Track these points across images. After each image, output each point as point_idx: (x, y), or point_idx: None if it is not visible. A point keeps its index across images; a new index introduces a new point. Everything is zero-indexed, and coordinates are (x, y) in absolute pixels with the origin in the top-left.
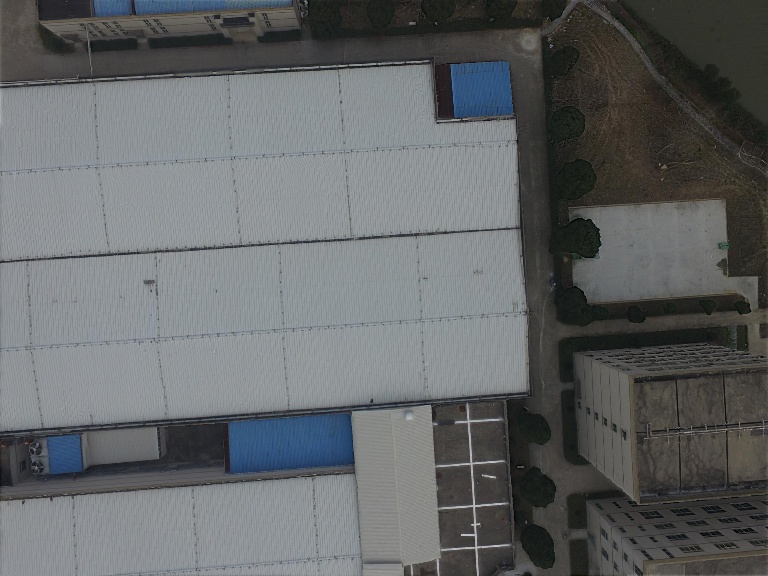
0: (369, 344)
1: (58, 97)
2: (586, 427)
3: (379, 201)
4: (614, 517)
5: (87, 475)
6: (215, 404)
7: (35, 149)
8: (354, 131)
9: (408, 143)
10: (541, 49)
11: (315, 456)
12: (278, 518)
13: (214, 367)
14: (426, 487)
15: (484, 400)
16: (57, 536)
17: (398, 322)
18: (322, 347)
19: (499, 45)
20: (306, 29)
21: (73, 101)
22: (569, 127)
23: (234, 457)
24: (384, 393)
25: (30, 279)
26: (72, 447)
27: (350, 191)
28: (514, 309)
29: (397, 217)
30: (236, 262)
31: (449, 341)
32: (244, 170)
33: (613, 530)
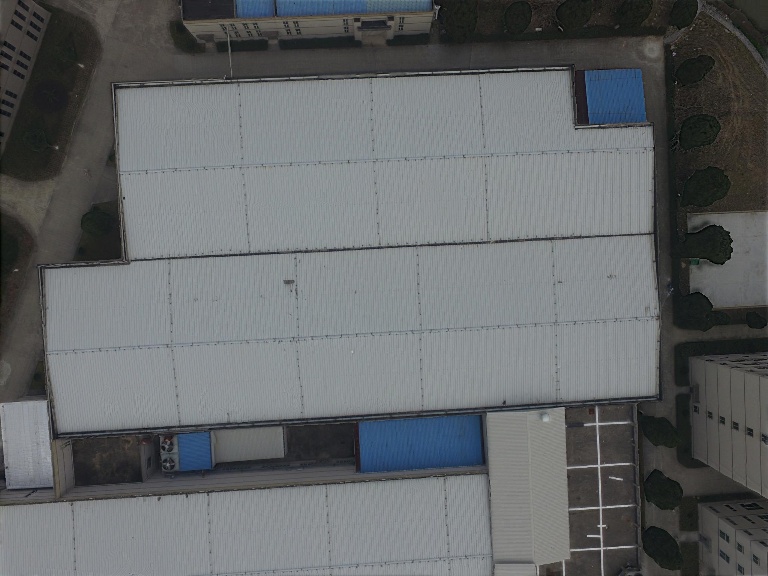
0: (504, 346)
1: (203, 97)
2: (706, 431)
3: (516, 205)
4: (734, 520)
5: (214, 472)
6: (353, 404)
7: (180, 148)
8: (494, 135)
9: (547, 148)
10: (664, 57)
11: (444, 456)
12: (410, 517)
13: (351, 367)
14: (558, 488)
15: (615, 403)
16: (192, 533)
17: (533, 325)
18: (458, 349)
19: (623, 52)
20: (434, 33)
21: (218, 101)
22: (706, 135)
23: (364, 456)
24: (516, 395)
25: (171, 277)
26: (202, 444)
27: (488, 195)
28: (647, 314)
29: (533, 221)
30: (375, 263)
31: (582, 344)
32: (386, 172)
33: (738, 533)
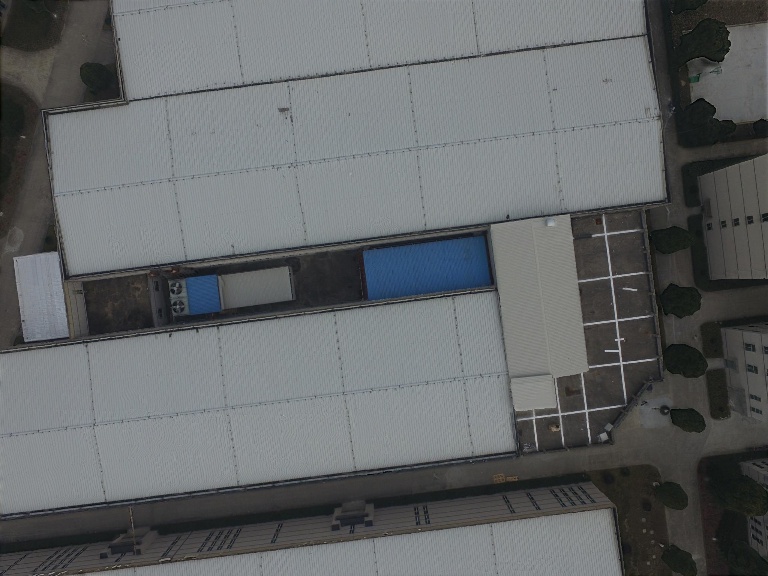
0: (503, 158)
1: None
2: (721, 243)
3: (504, 16)
4: (759, 330)
5: (224, 317)
6: (355, 224)
7: None
8: None
9: None
10: None
11: (451, 280)
12: (421, 339)
13: (351, 190)
14: (570, 298)
15: (622, 209)
16: (205, 367)
17: (531, 134)
18: (456, 164)
19: None
20: None
21: None
22: None
23: (371, 285)
24: (520, 208)
25: (169, 114)
26: (210, 287)
27: (475, 8)
28: (647, 115)
29: (523, 31)
30: (367, 85)
31: (583, 151)
32: None
33: (764, 335)
